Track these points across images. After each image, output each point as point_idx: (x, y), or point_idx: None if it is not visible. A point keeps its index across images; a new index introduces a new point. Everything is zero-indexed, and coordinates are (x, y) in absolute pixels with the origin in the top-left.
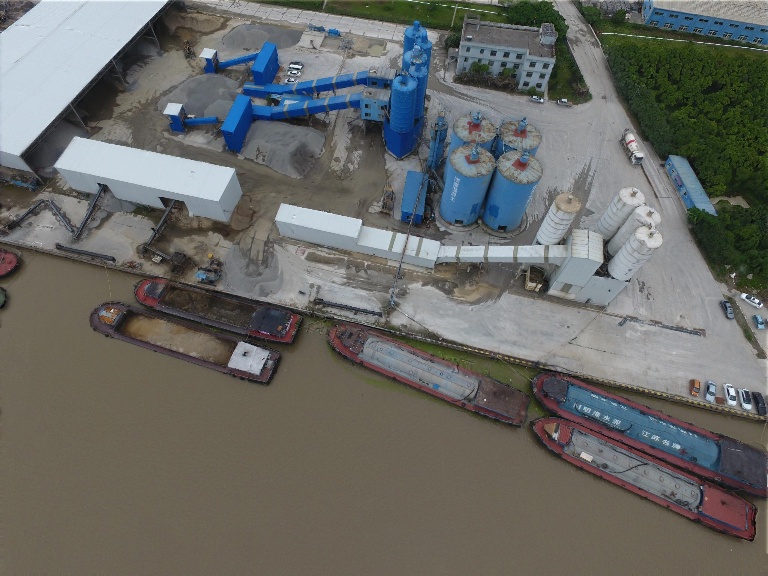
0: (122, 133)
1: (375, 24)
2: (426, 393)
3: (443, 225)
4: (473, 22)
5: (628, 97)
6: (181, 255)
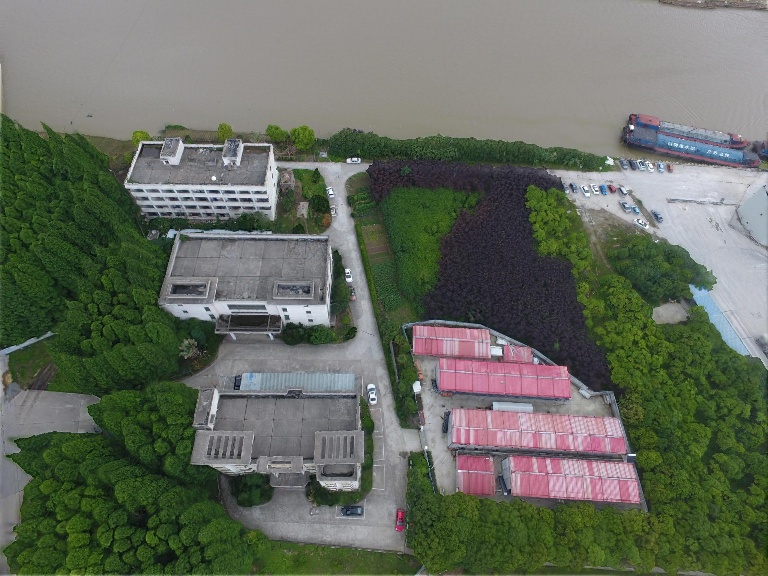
0: None
1: None
2: None
3: None
4: None
5: None
6: None
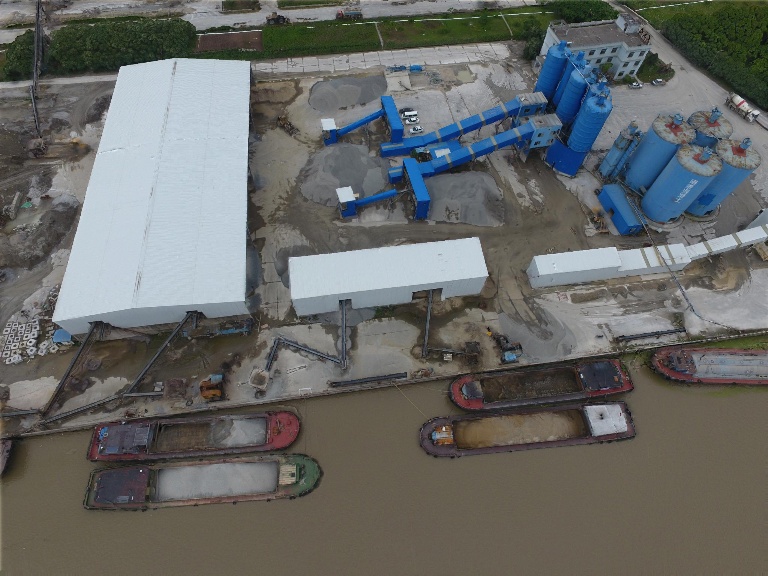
0: (291, 237)
1: (442, 50)
2: (765, 385)
3: (657, 227)
4: (564, 28)
5: (706, 63)
6: (472, 344)
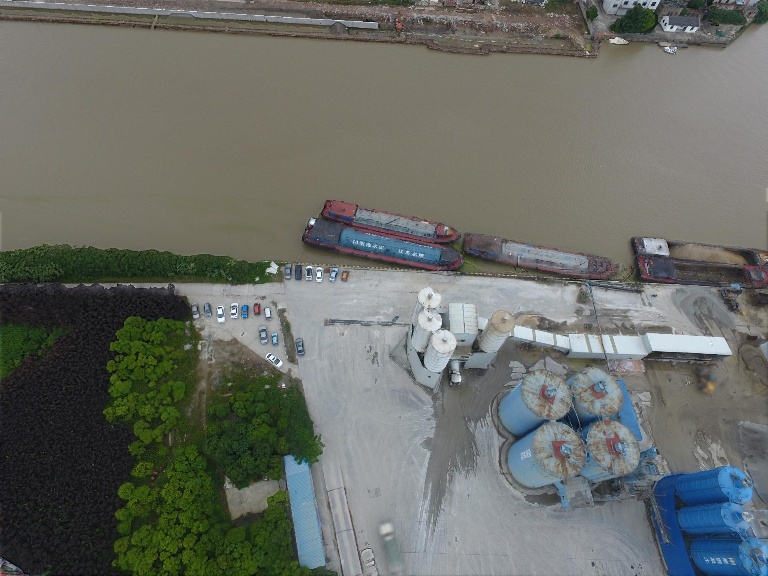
0: None
1: None
2: None
3: None
4: None
5: None
6: (765, 302)
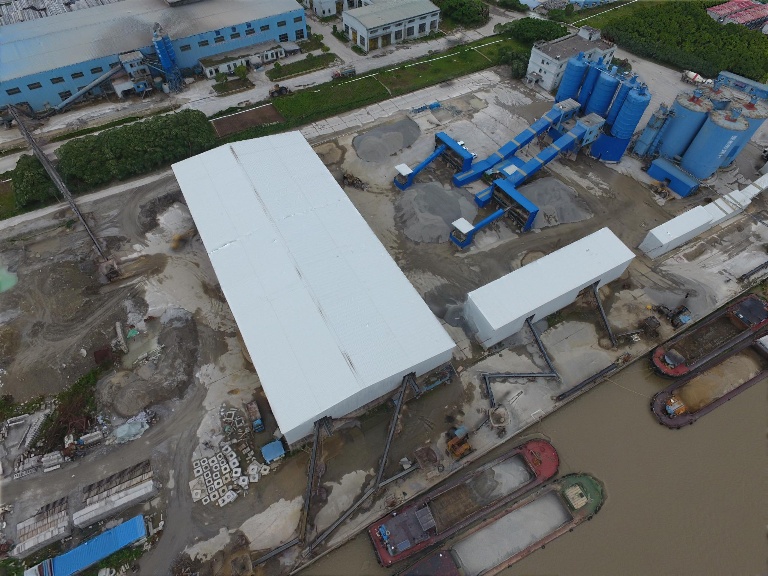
0: (427, 280)
1: (444, 86)
2: None
3: None
4: (548, 45)
5: (650, 53)
6: (648, 319)
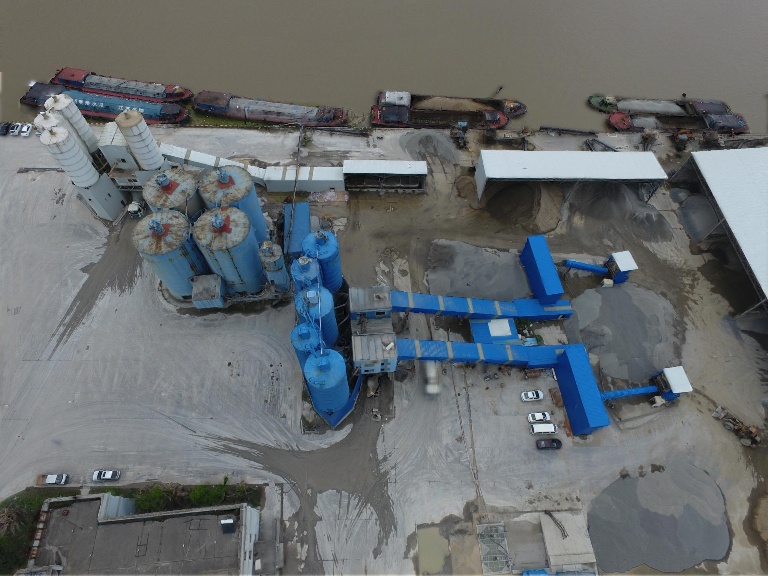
0: (665, 252)
1: None
2: None
3: None
4: (217, 573)
5: None
6: (490, 136)
